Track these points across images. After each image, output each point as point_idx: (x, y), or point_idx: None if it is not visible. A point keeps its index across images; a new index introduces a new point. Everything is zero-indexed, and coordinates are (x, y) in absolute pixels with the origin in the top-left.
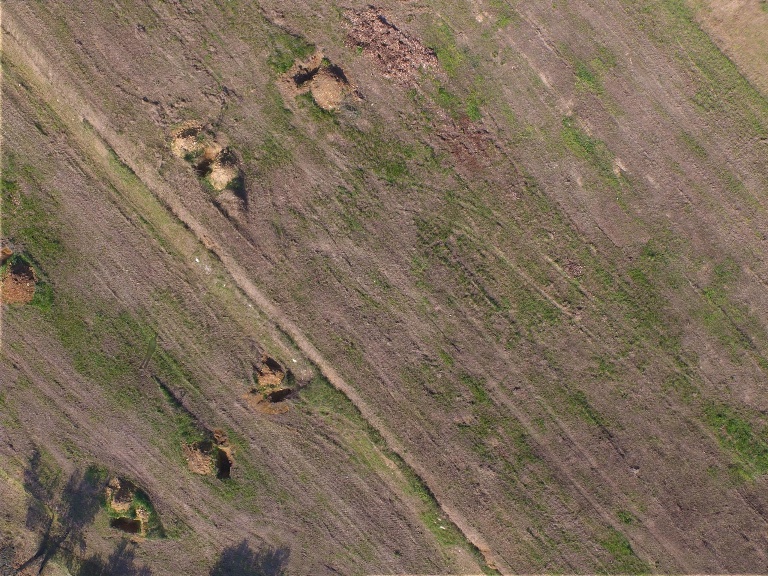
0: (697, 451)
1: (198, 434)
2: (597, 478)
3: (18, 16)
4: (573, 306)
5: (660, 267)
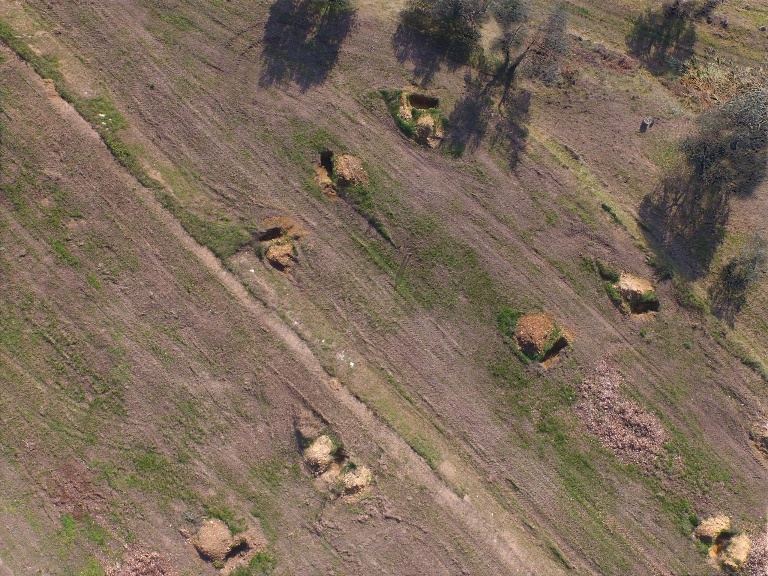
0: None
1: (351, 194)
2: None
3: None
4: None
5: None
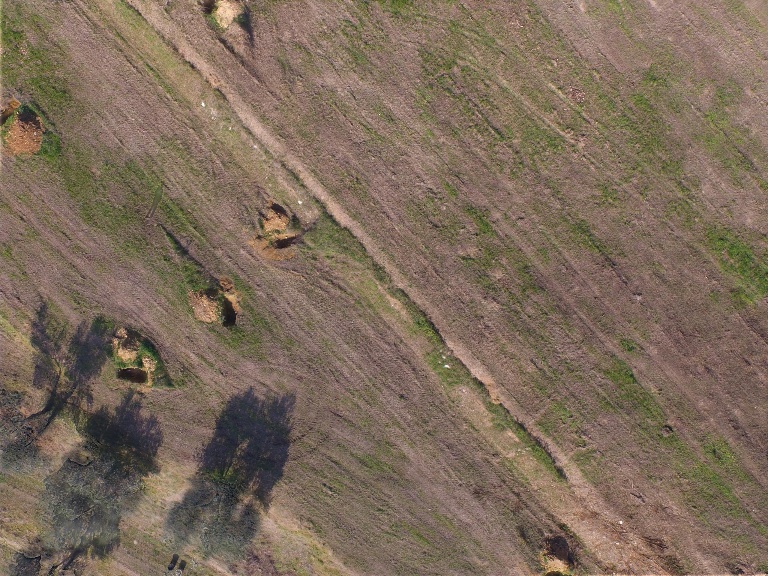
0: (699, 276)
1: (204, 281)
2: (600, 307)
3: None
4: (576, 133)
5: (662, 92)
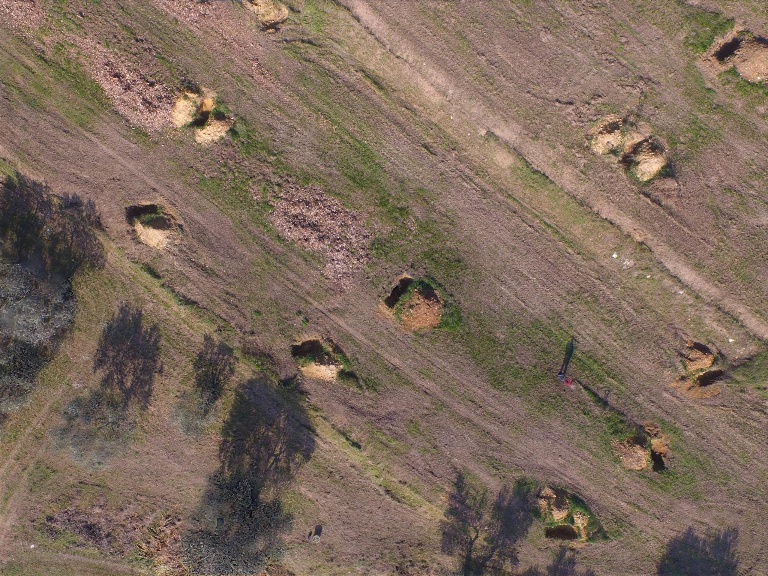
0: None
1: (630, 430)
2: None
3: (414, 38)
4: None
5: None
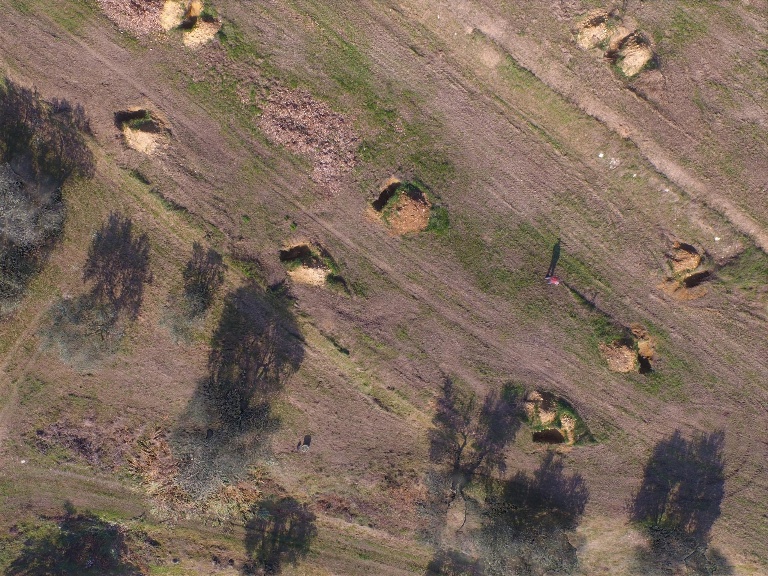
0: None
1: (617, 332)
2: None
3: None
4: None
5: None
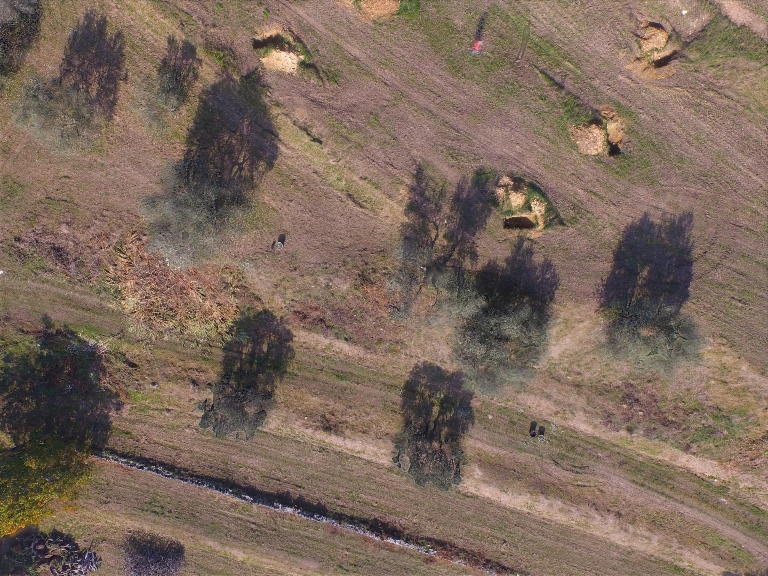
0: None
1: (586, 114)
2: None
3: None
4: None
5: None
